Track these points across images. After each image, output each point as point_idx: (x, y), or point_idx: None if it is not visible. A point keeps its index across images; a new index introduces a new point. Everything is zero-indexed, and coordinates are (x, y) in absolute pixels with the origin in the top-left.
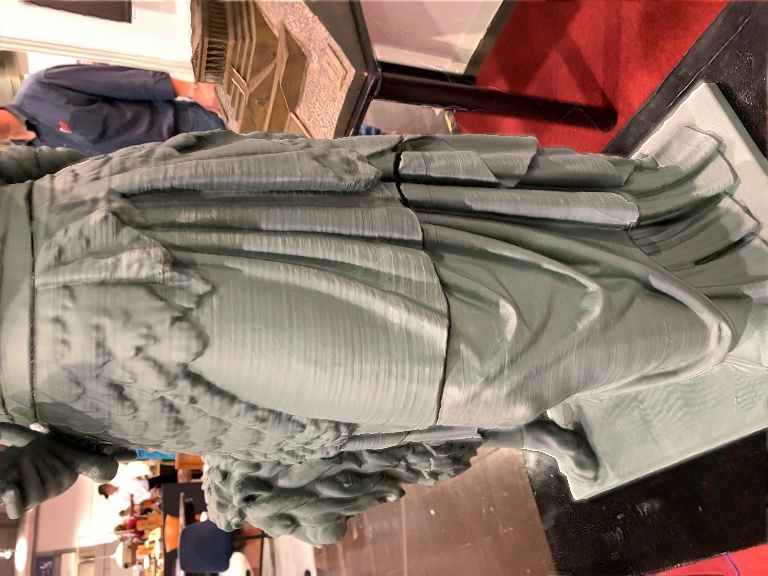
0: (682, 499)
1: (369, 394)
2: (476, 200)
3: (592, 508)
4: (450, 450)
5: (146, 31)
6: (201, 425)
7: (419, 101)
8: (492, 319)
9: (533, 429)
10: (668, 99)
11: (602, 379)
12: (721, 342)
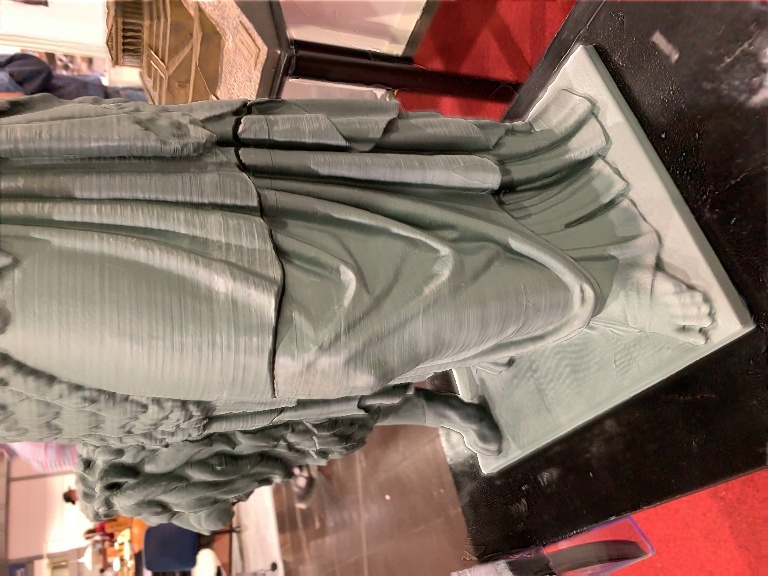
0: (576, 466)
1: (193, 367)
2: (322, 164)
3: (500, 481)
4: (334, 427)
5: (67, 15)
6: (26, 409)
7: (341, 80)
8: (332, 286)
9: (435, 404)
10: (553, 64)
11: (456, 345)
12: (584, 304)
